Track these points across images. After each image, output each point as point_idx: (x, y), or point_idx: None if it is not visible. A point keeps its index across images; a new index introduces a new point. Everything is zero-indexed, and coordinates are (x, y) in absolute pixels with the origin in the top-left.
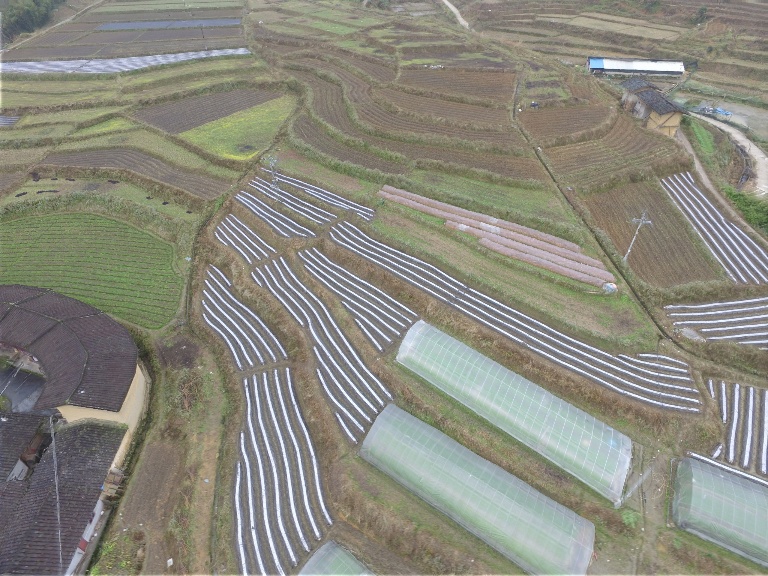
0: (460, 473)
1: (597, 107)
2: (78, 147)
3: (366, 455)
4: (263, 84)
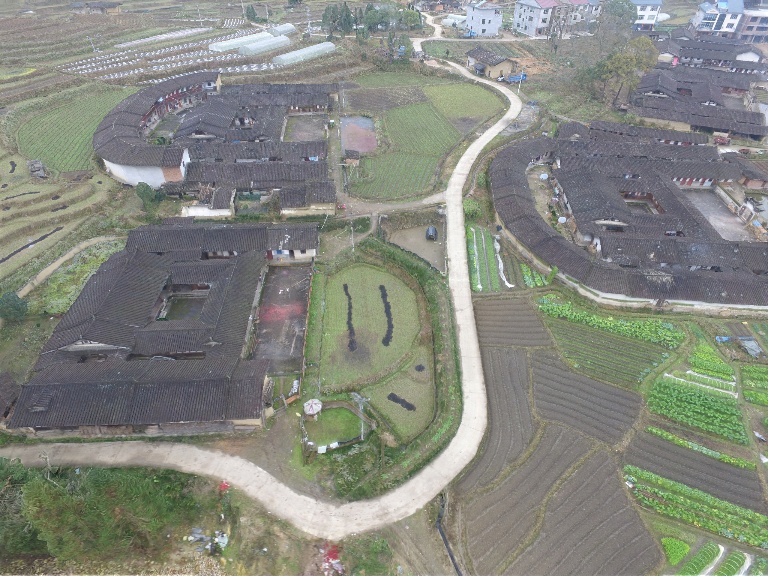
0: None
1: None
2: None
3: None
4: None
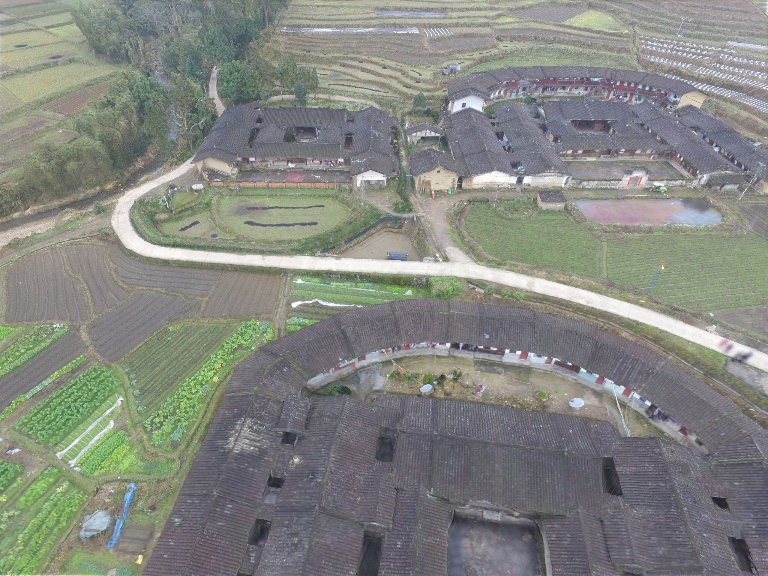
0: None
1: None
2: (508, 27)
3: None
4: (569, 4)
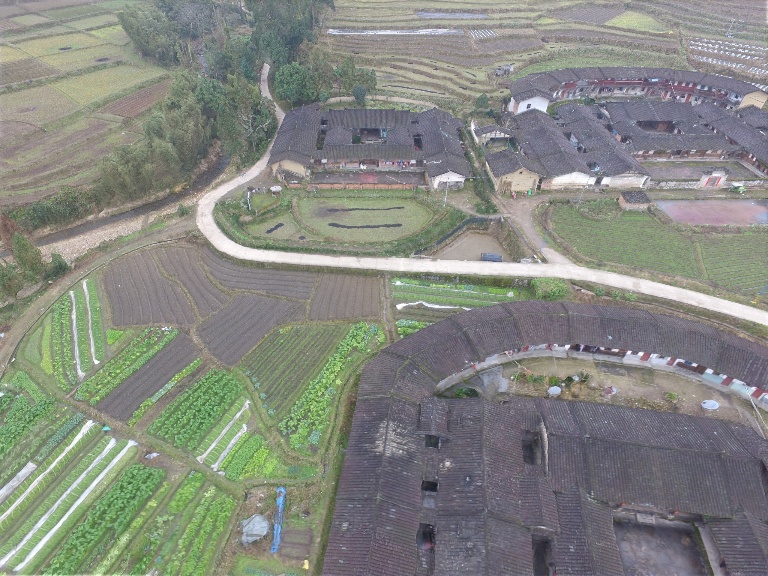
0: None
1: None
2: (551, 28)
3: None
4: (606, 5)
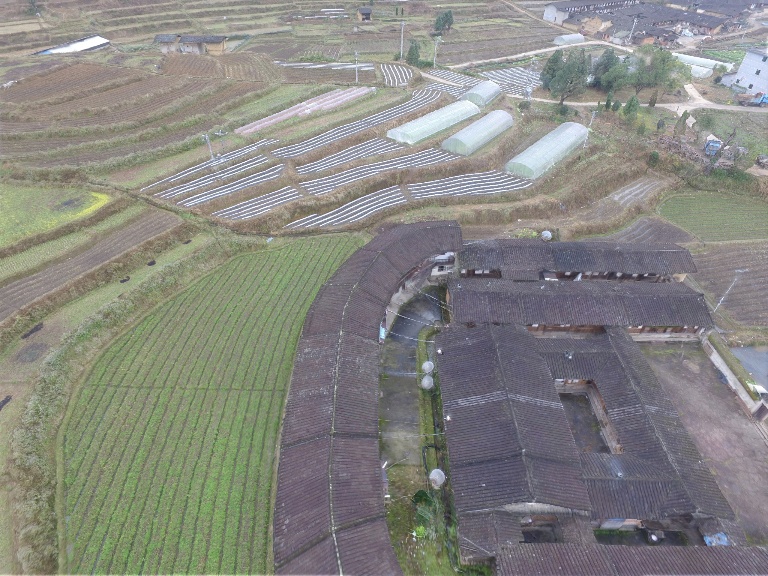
0: (480, 125)
1: (178, 57)
2: None
3: (470, 150)
4: None
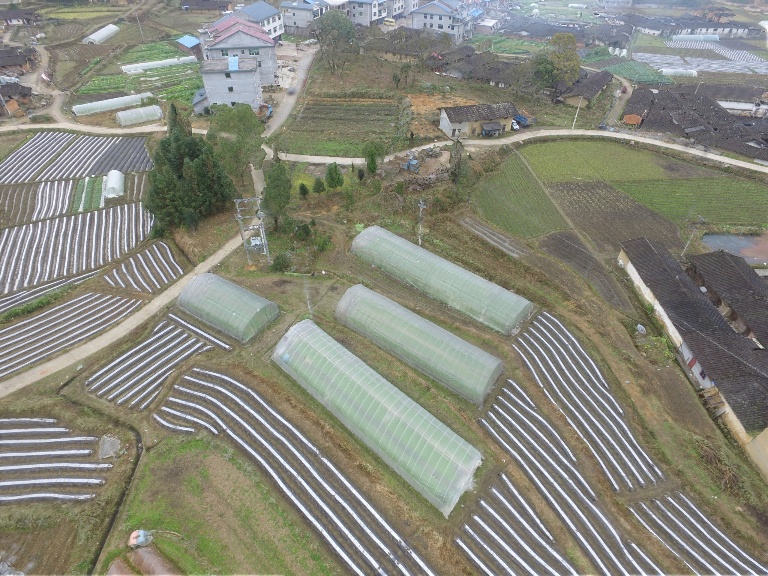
0: (424, 327)
1: None
2: None
3: None
4: None
